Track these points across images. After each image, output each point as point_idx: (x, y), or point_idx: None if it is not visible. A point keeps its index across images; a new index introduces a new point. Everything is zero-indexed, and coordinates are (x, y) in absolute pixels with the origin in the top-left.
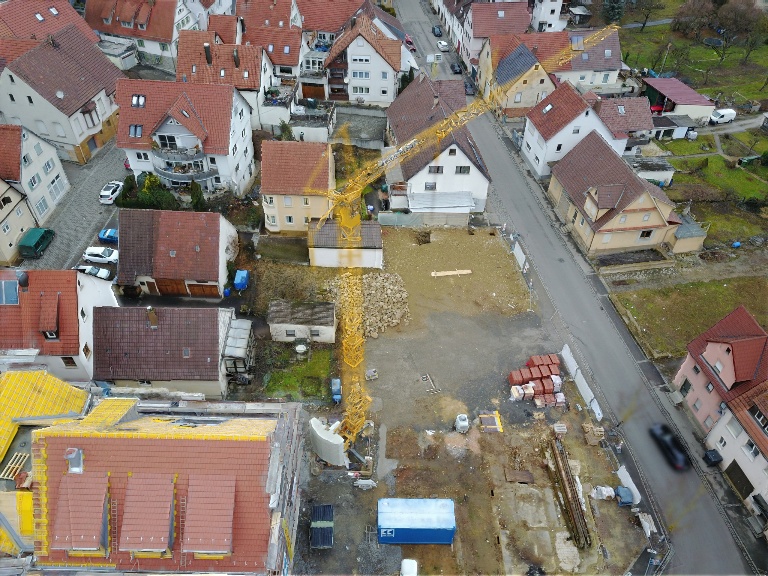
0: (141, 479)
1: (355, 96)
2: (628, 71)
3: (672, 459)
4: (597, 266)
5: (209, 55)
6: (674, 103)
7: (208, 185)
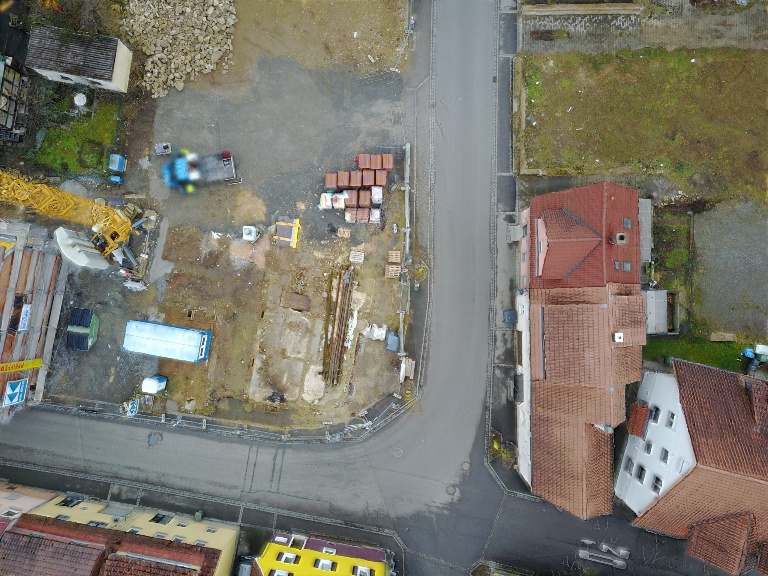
0: None
1: None
2: None
3: (470, 306)
4: None
5: None
6: None
7: None
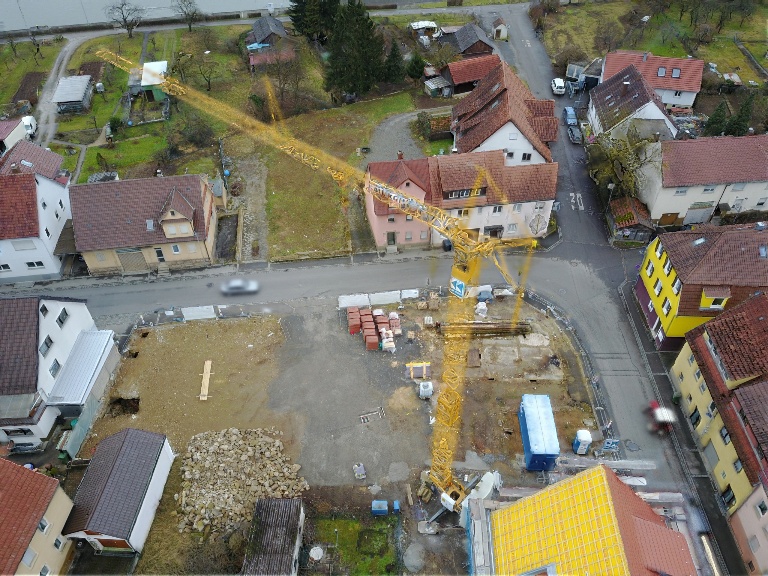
0: None
1: None
2: None
3: (447, 267)
4: (228, 261)
5: None
6: None
7: None
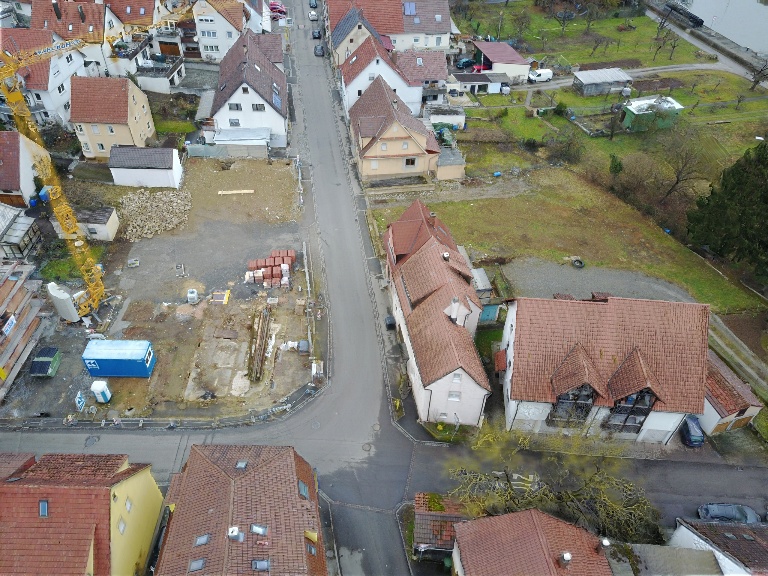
0: None
1: (206, 54)
2: (459, 35)
3: (361, 325)
4: None
5: (58, 11)
6: (491, 62)
7: (38, 119)
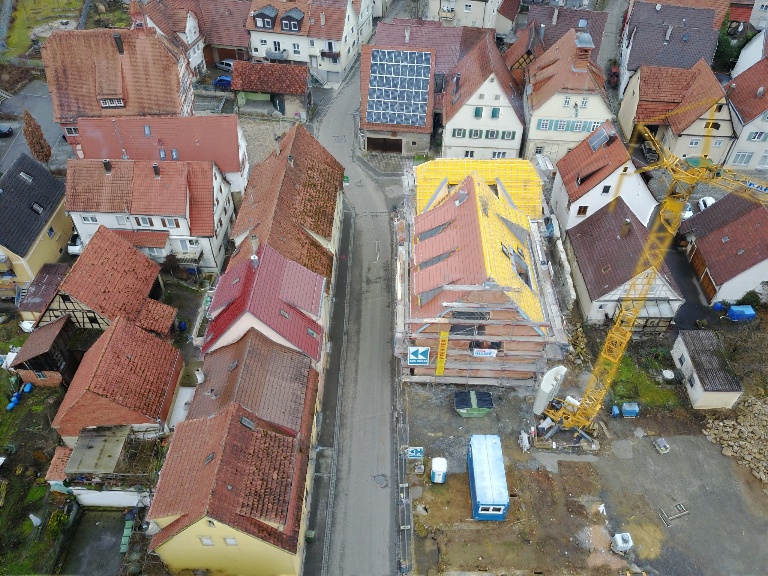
0: (456, 233)
1: None
2: None
3: None
4: None
5: None
6: None
7: None
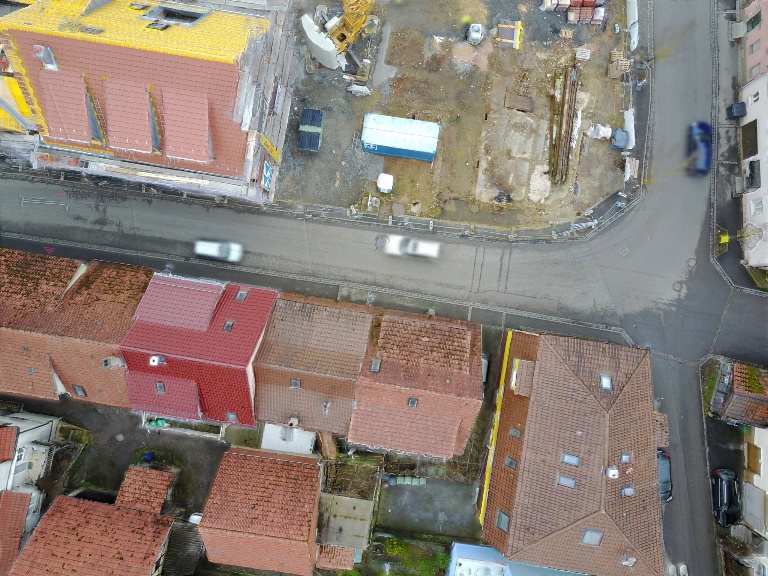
0: (115, 84)
1: None
2: None
3: (692, 105)
4: None
5: None
6: None
7: None
